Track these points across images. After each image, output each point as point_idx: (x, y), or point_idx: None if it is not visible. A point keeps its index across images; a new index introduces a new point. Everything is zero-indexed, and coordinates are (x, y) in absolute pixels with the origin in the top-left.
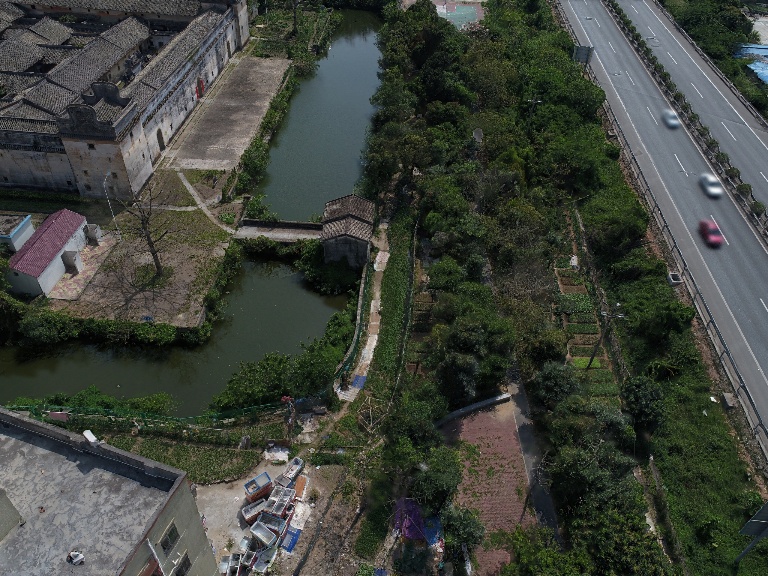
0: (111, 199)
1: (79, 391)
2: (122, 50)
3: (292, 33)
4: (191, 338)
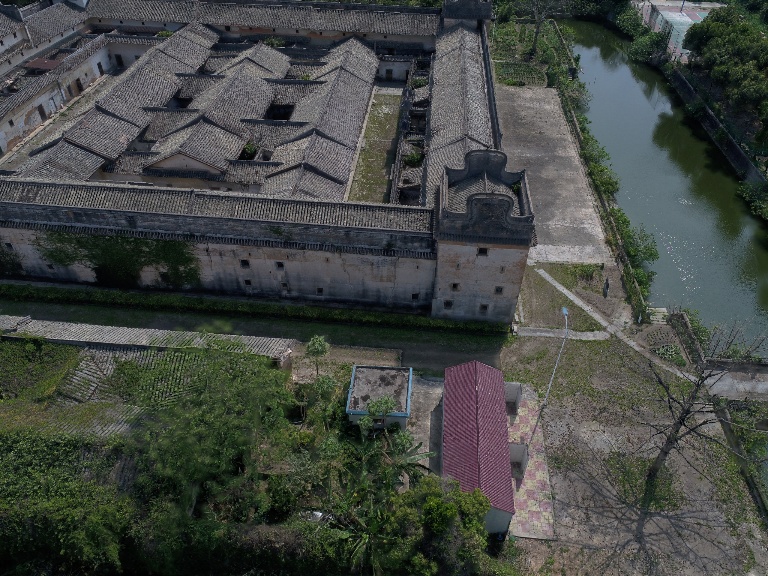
0: (485, 323)
1: None
2: (366, 83)
3: (530, 53)
4: None
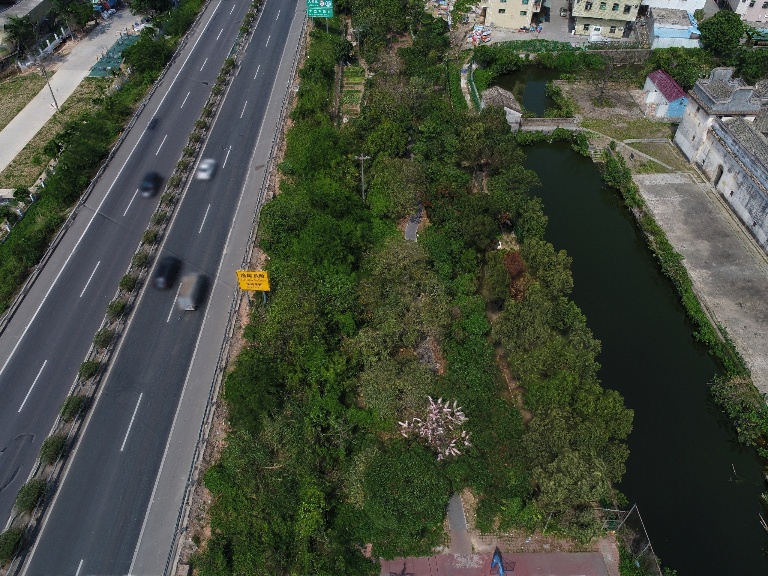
0: None
1: None
2: None
3: None
4: None
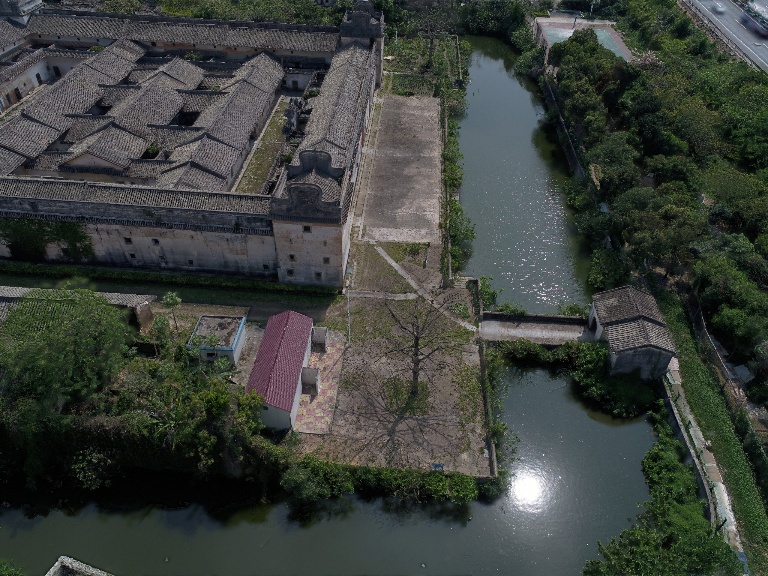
0: (319, 287)
1: (377, 575)
2: (266, 94)
3: (426, 66)
4: (493, 492)
